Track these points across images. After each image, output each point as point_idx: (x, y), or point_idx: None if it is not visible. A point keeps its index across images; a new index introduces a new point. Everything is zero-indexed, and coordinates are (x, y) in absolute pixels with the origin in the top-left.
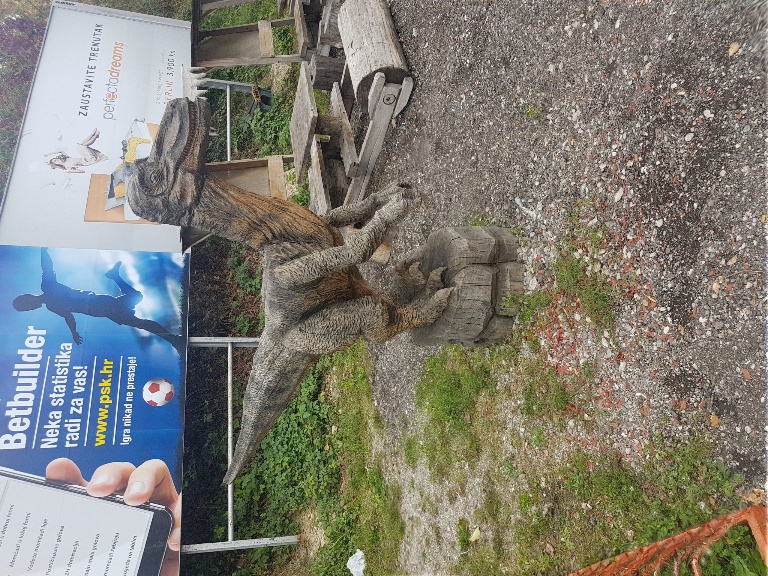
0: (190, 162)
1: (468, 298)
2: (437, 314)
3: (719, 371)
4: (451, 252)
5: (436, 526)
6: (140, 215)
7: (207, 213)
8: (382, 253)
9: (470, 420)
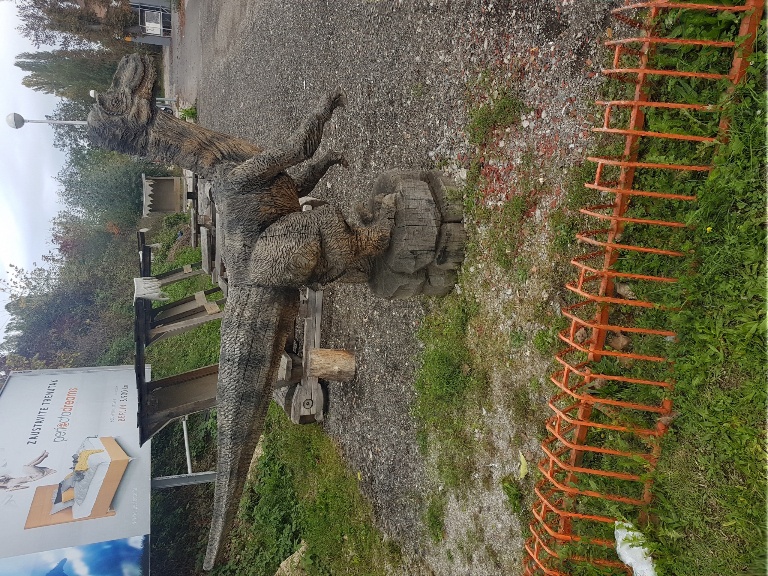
0: (145, 93)
1: (412, 198)
2: (390, 223)
3: (591, 7)
4: (386, 180)
5: (487, 548)
6: (102, 135)
7: (162, 133)
8: (347, 361)
9: (469, 367)
